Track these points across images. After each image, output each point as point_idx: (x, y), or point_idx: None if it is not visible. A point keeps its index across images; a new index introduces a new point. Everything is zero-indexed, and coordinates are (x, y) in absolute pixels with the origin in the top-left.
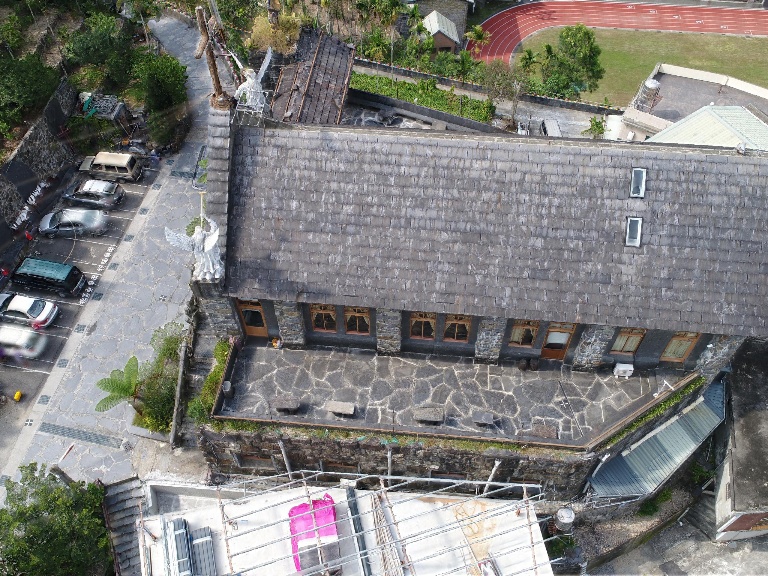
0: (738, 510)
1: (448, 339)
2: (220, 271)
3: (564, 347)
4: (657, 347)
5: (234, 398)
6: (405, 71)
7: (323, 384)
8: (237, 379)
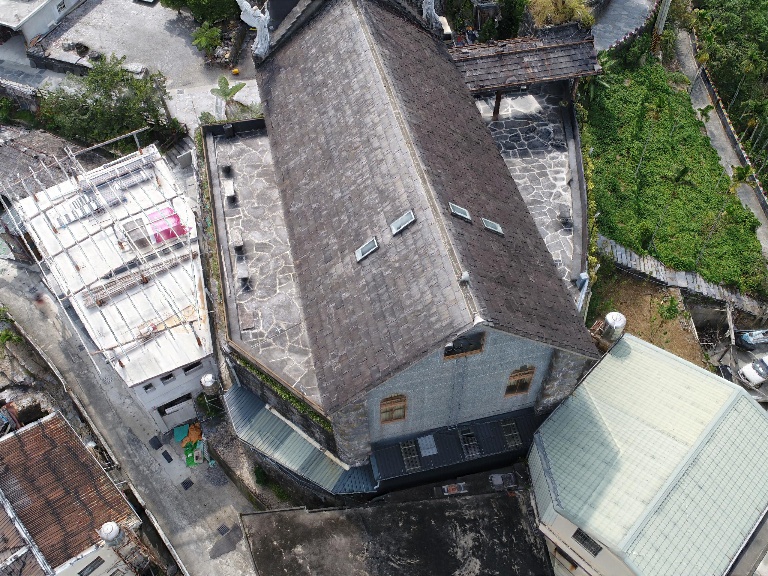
0: (241, 516)
1: None
2: (261, 51)
3: None
4: None
5: (227, 138)
6: (765, 201)
7: (252, 179)
8: (243, 135)
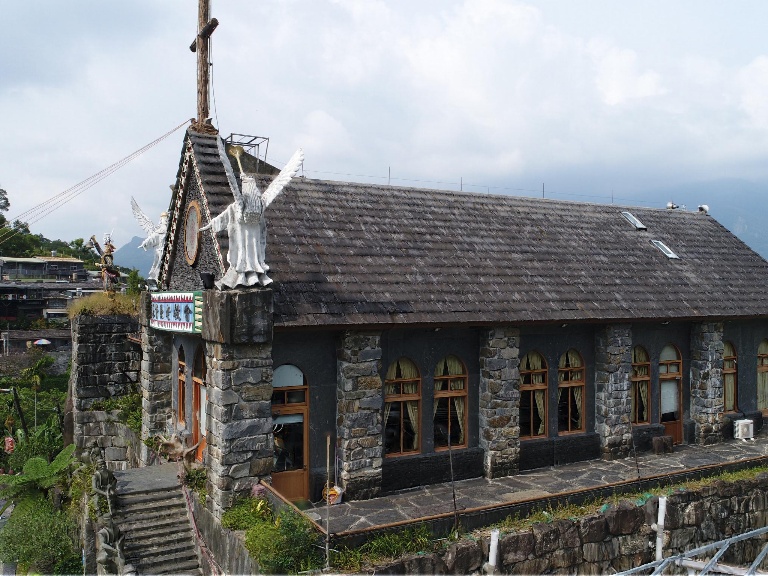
0: None
1: (561, 433)
2: None
3: (676, 418)
4: (751, 388)
5: None
6: None
7: None
8: None
